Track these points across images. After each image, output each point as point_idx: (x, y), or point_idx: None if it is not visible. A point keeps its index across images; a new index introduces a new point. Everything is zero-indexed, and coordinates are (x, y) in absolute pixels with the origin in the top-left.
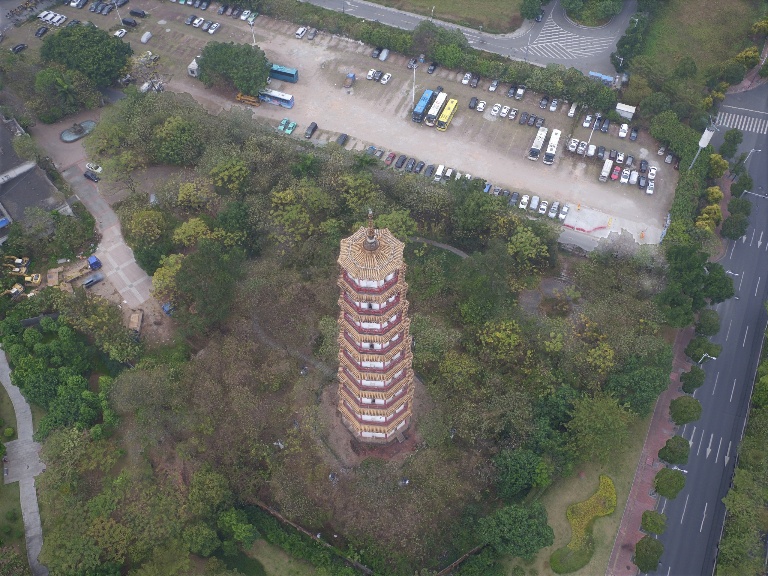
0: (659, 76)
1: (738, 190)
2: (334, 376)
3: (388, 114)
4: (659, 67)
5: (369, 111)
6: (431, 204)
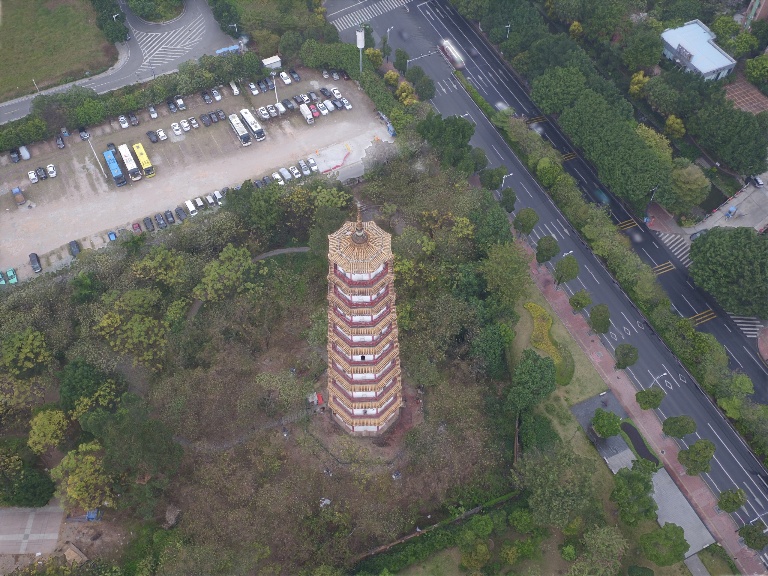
0: (273, 21)
1: (402, 64)
2: (306, 415)
3: (90, 197)
4: (266, 14)
5: (69, 208)
6: (227, 231)
